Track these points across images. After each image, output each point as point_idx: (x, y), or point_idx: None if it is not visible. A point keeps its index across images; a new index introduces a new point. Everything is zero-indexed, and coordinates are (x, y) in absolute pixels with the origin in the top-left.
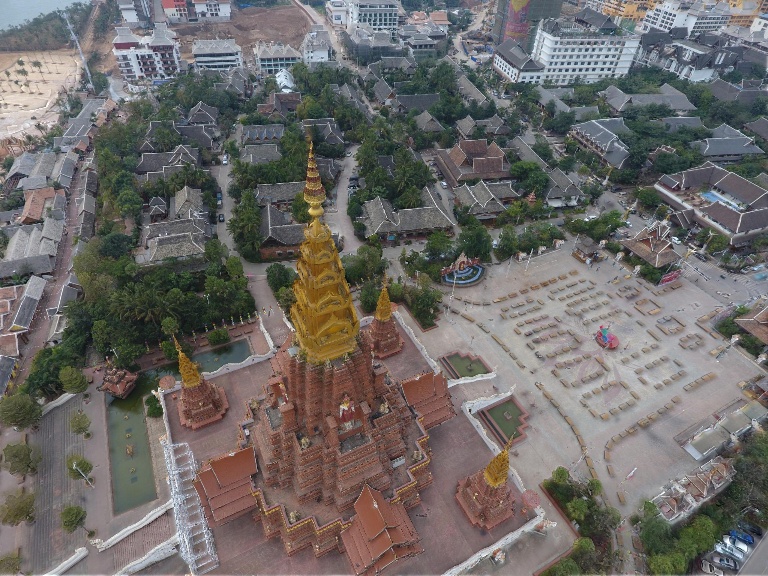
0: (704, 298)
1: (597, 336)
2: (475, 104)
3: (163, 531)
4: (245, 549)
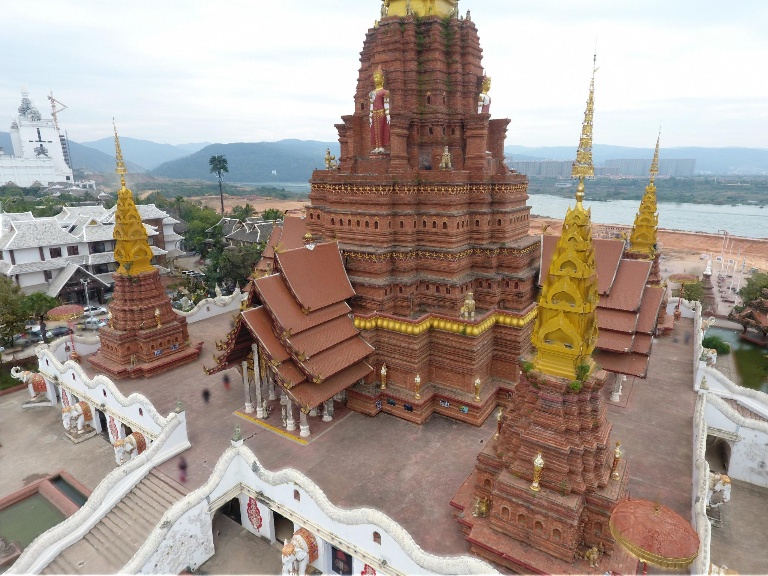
0: None
1: None
2: None
3: None
4: None
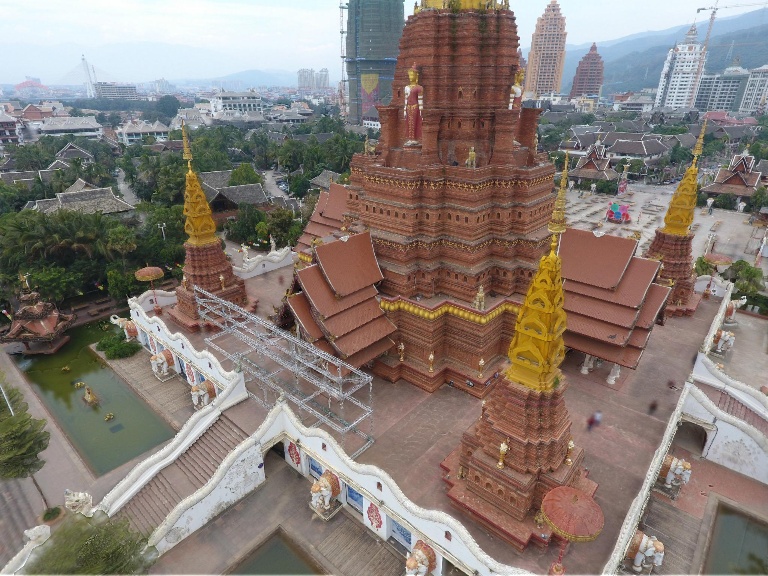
0: (658, 196)
1: (608, 217)
2: (371, 133)
3: (228, 441)
4: (403, 412)
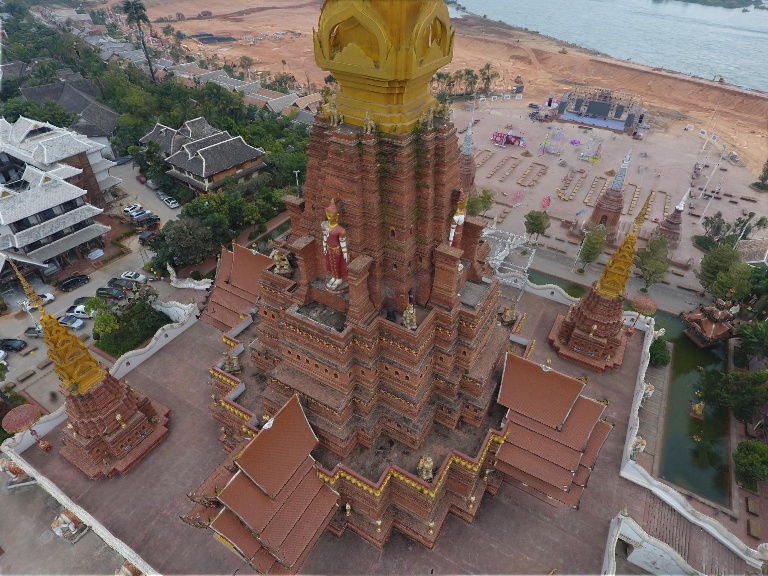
0: None
1: None
2: None
3: None
4: None
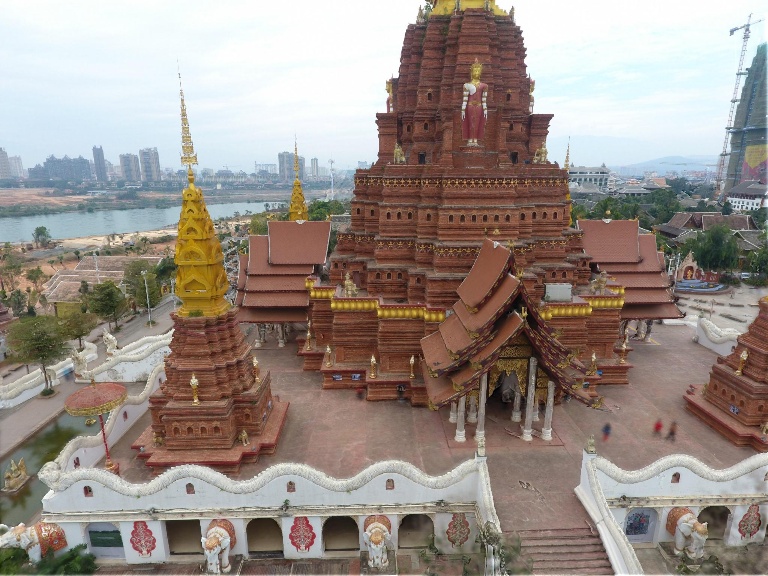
0: None
1: None
2: (702, 206)
3: None
4: None
